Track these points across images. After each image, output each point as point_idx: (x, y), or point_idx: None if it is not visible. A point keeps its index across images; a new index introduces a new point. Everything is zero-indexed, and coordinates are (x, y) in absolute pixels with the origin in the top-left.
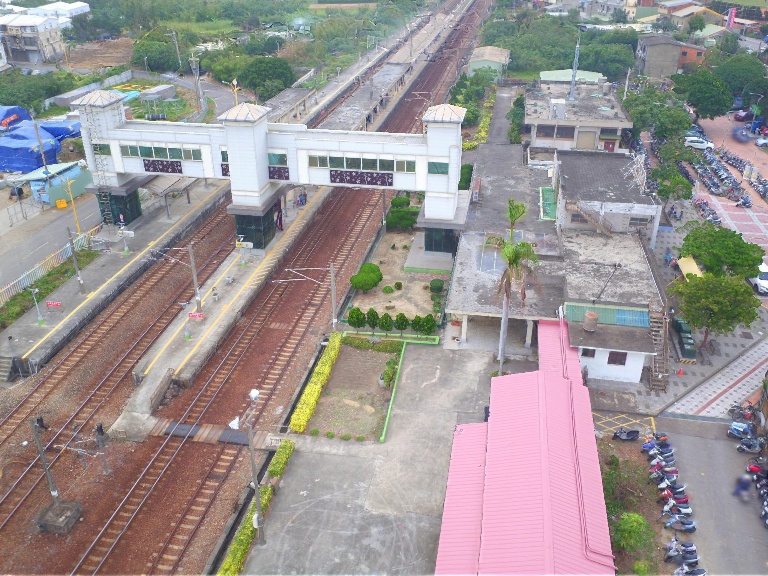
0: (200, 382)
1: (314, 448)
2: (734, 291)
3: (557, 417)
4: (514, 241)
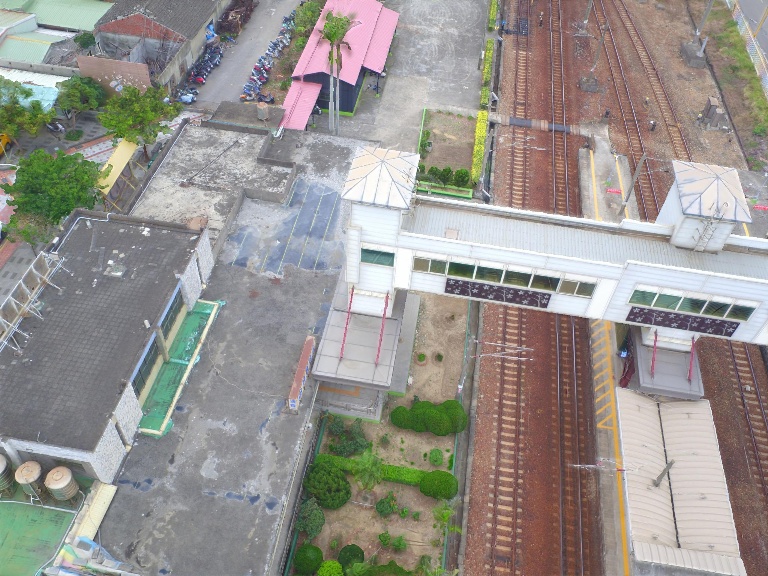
0: (573, 162)
1: (468, 110)
2: (134, 90)
3: (324, 50)
4: (281, 248)
